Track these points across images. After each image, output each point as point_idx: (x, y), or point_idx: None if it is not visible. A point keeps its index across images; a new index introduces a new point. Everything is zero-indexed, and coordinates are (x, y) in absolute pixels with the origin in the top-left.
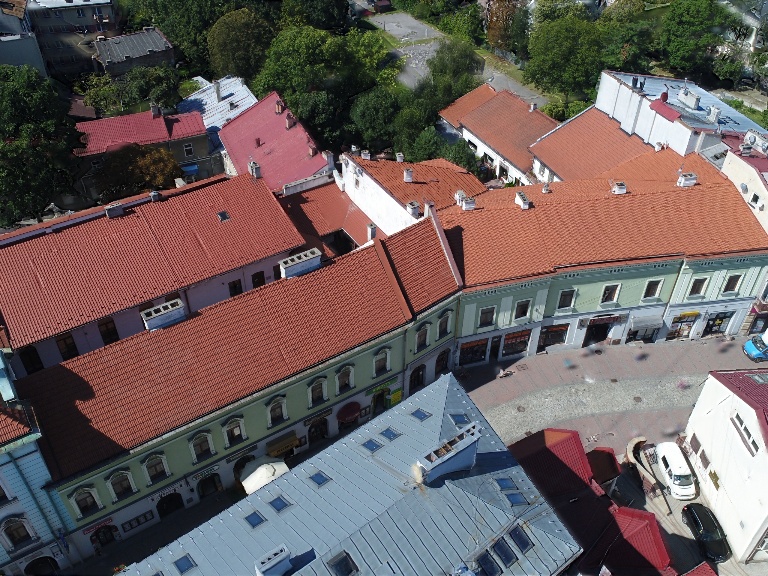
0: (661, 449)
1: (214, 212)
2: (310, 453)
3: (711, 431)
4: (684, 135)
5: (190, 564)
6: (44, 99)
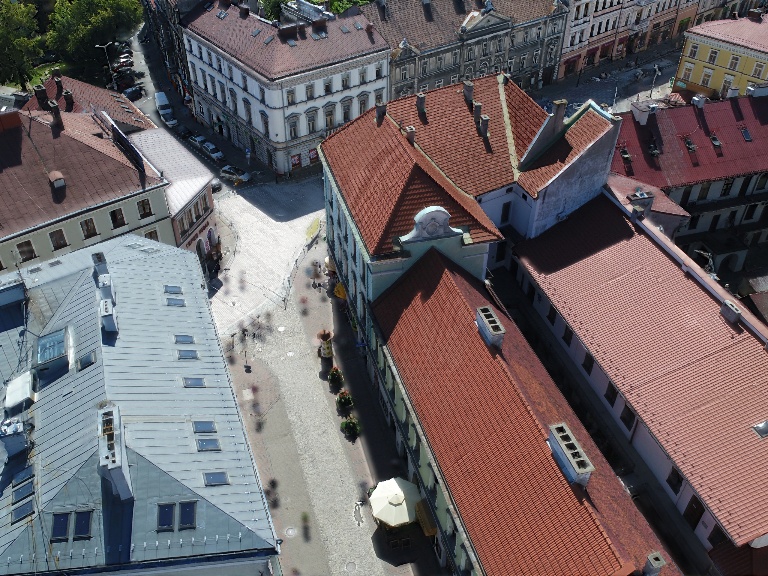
0: None
1: None
2: (437, 568)
3: None
4: None
5: (174, 304)
6: None
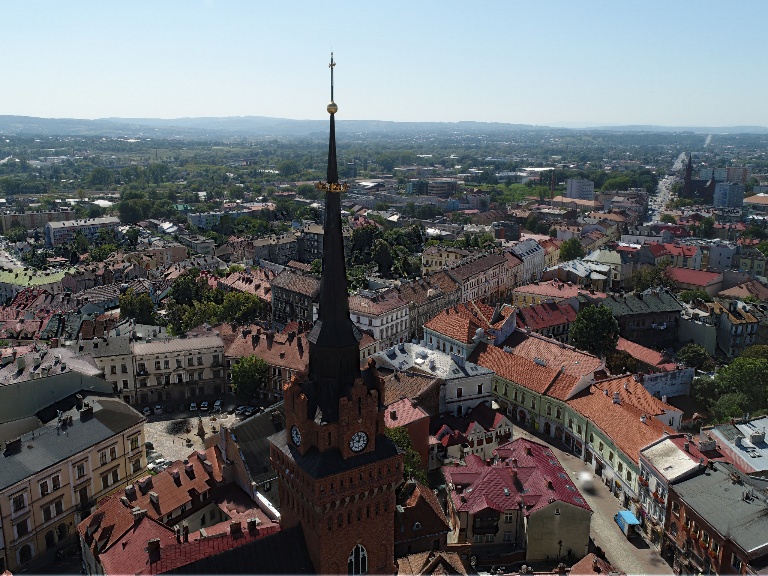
0: None
1: None
2: None
3: None
4: None
5: None
6: (602, 319)
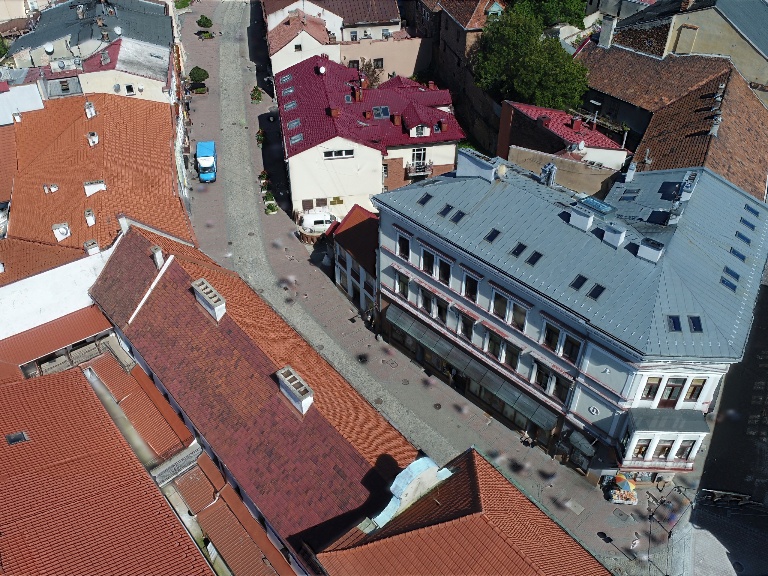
0: (309, 222)
1: (6, 448)
2: None
3: (316, 183)
4: (31, 92)
5: (578, 280)
6: None
